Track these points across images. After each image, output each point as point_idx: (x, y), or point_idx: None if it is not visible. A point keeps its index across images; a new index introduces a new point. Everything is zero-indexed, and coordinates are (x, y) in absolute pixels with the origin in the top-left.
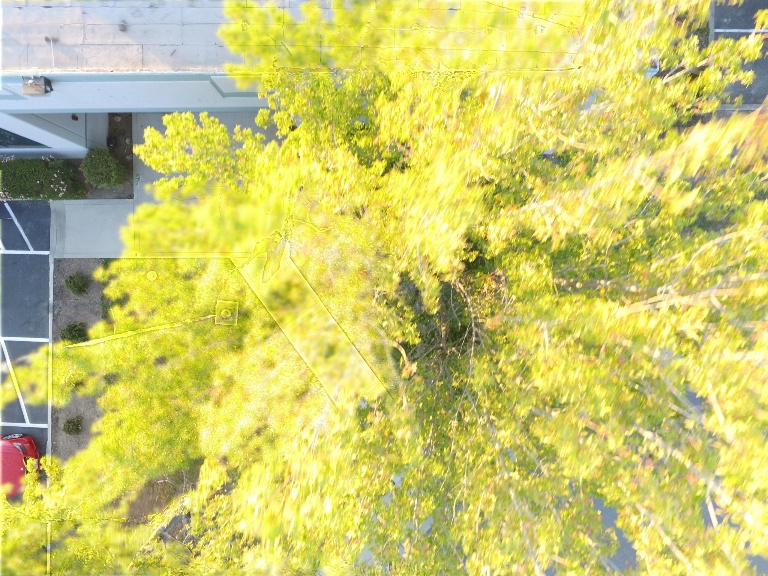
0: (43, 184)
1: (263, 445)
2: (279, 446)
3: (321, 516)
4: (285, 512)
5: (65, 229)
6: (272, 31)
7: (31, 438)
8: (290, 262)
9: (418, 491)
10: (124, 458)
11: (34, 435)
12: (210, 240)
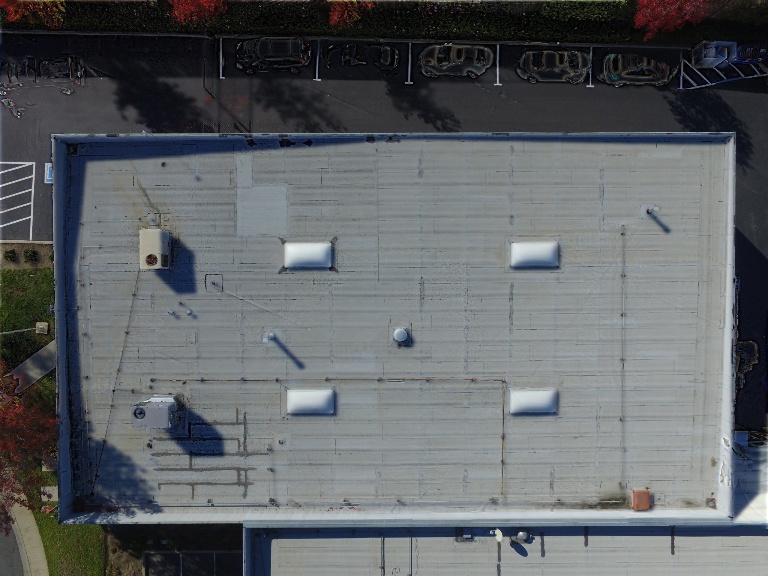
0: None
1: None
2: None
3: None
4: None
5: None
6: None
7: None
8: None
9: None
10: None
11: None
12: None
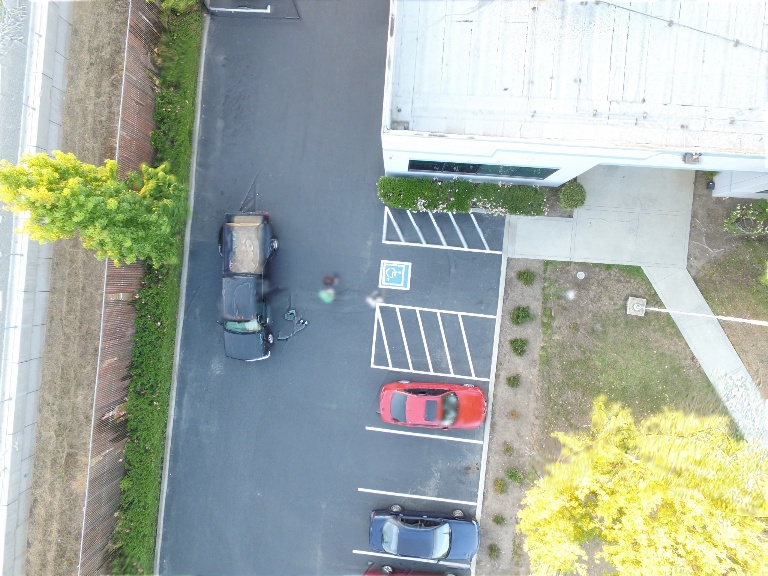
0: (533, 205)
1: (660, 405)
2: (671, 407)
3: (692, 461)
4: (670, 456)
5: (516, 236)
6: None
7: (480, 388)
8: (687, 272)
9: (765, 449)
10: (555, 407)
11: (479, 386)
12: (628, 252)
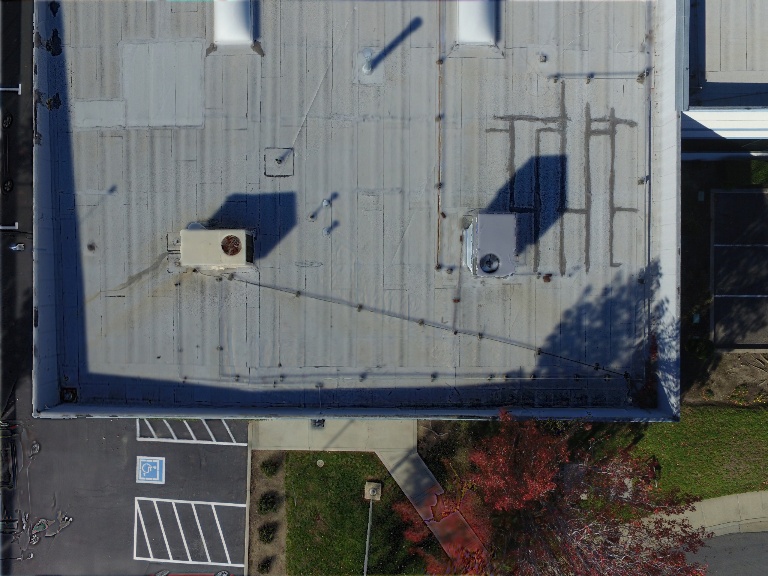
0: None
1: None
2: None
3: None
4: None
5: (259, 429)
6: (449, 381)
7: (234, 575)
8: (417, 456)
9: None
10: None
11: (235, 572)
12: (362, 439)
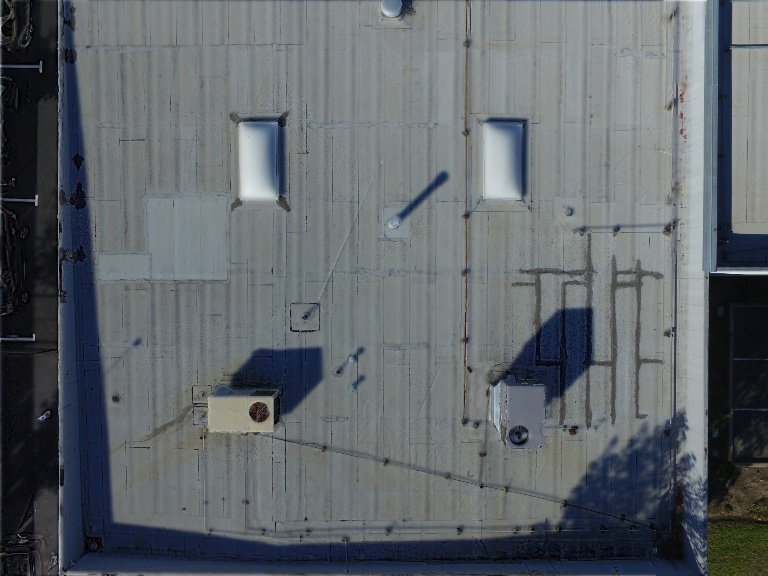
0: None
1: None
2: None
3: None
4: None
5: None
6: (475, 535)
7: None
8: None
9: None
10: None
11: None
12: None
